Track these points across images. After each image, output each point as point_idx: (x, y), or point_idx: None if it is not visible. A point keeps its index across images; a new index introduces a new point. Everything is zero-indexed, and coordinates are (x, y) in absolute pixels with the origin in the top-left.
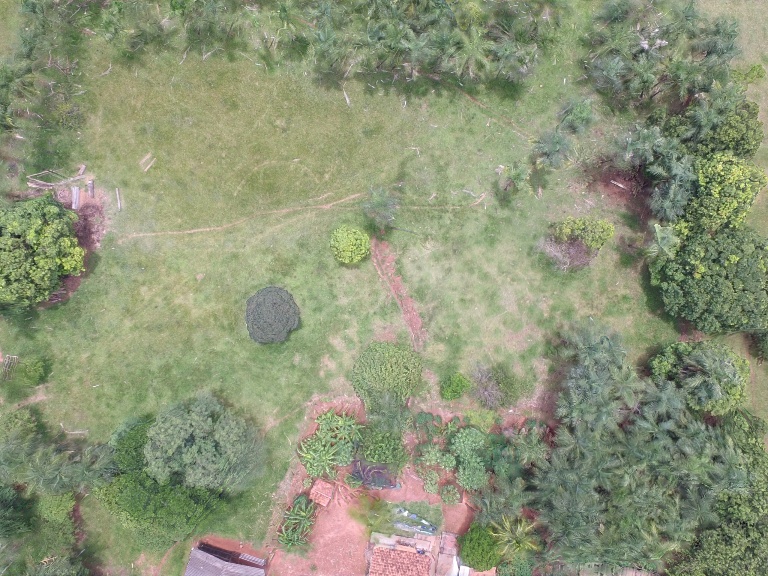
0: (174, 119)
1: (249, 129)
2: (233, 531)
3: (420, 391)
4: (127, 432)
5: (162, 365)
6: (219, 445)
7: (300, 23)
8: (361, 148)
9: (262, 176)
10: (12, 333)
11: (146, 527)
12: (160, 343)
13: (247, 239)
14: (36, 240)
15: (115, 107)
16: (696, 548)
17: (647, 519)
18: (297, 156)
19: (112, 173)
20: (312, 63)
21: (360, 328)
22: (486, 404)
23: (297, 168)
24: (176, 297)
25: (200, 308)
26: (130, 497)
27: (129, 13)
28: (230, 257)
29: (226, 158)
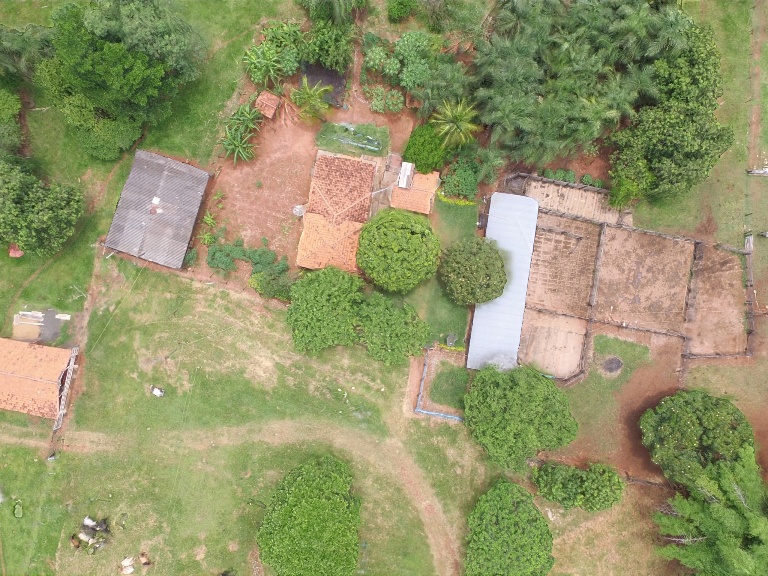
0: None
1: None
2: (180, 148)
3: (368, 16)
4: (69, 10)
5: None
6: (158, 9)
7: None
8: None
9: None
10: None
11: (90, 126)
12: None
13: None
14: None
15: None
16: (636, 123)
17: (587, 92)
18: None
19: None
20: None
21: None
22: (434, 28)
23: None
24: None
25: None
26: (67, 43)
27: None
28: None
29: None
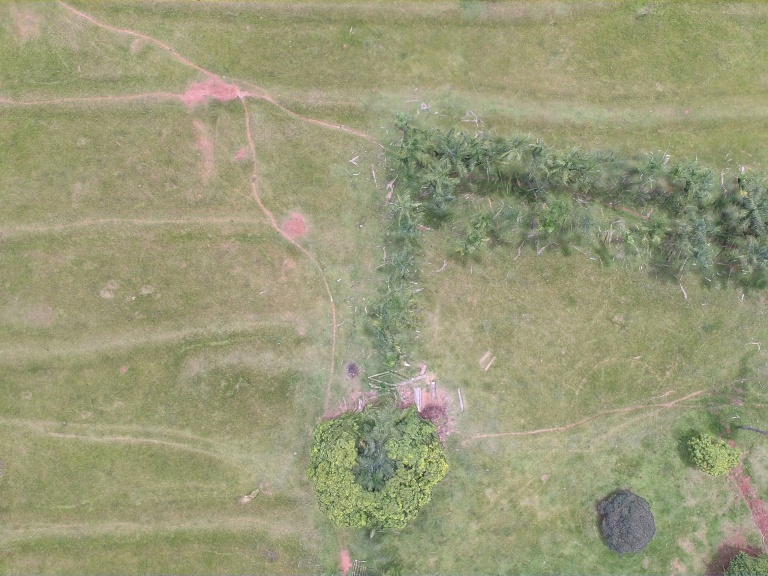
0: (511, 316)
1: (587, 326)
2: None
3: None
4: None
5: (511, 570)
6: None
7: (633, 216)
8: (702, 344)
9: (604, 374)
10: (359, 537)
11: None
12: (508, 547)
13: (592, 440)
14: (425, 469)
15: (452, 304)
16: None
17: None
18: (637, 353)
19: (452, 372)
20: (647, 257)
21: (709, 530)
22: None
23: (638, 366)
24: (522, 499)
25: (546, 510)
26: None
27: (462, 208)
28: (575, 458)
29: (566, 356)
